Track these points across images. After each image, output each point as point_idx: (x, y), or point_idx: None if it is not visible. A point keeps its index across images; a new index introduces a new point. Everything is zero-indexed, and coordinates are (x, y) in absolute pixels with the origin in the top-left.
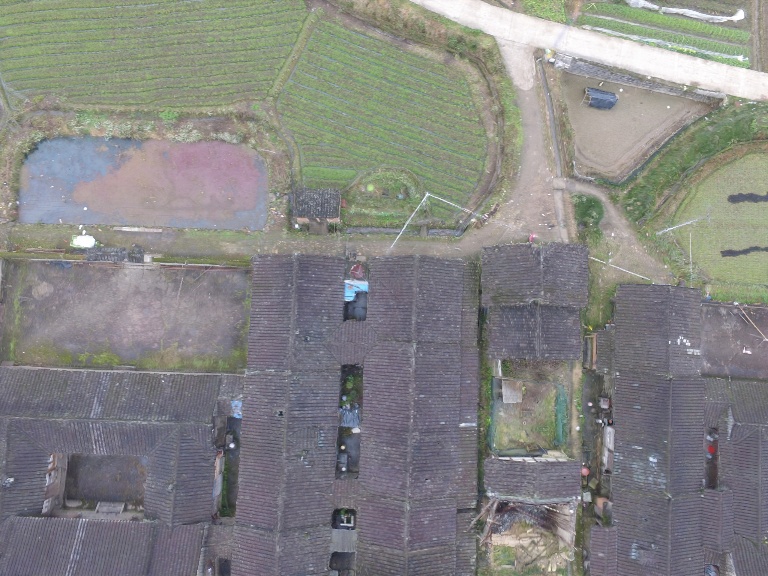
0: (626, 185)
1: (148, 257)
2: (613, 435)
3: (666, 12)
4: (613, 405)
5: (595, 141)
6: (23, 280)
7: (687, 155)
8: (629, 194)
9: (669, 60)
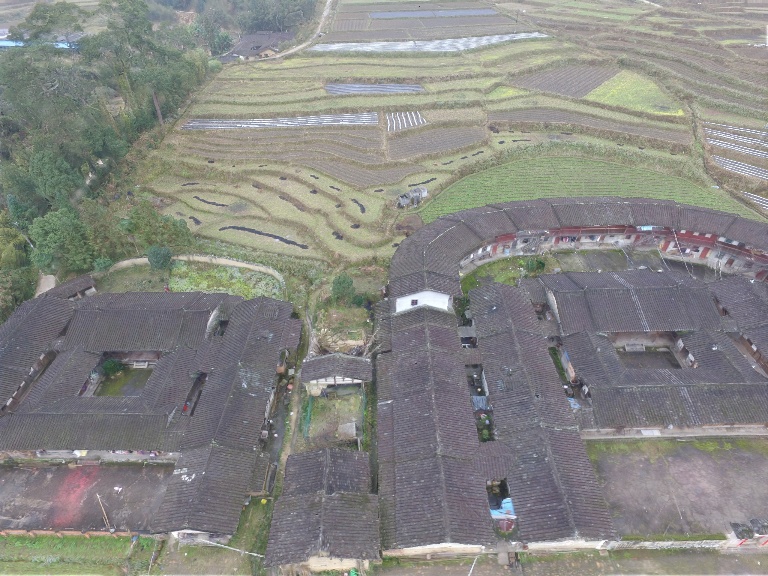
0: None
1: (731, 538)
2: None
3: None
4: None
5: None
6: None
7: None
8: None
9: None
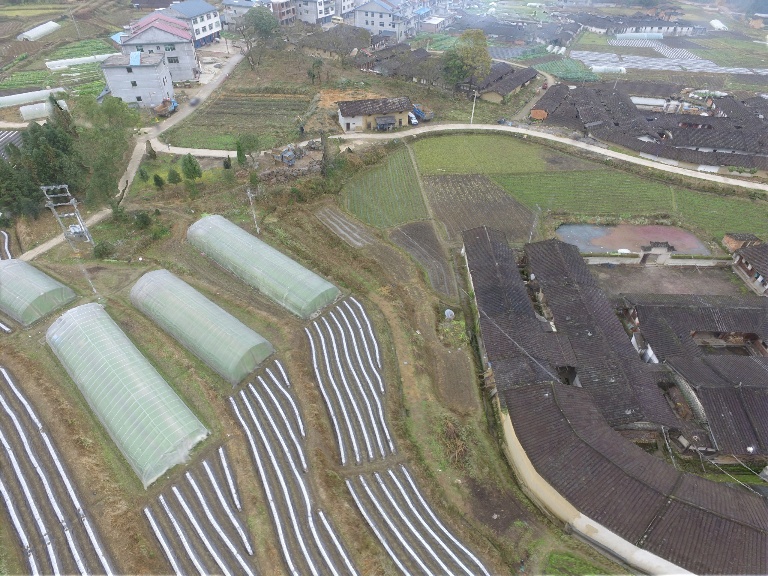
0: None
1: None
2: None
3: None
4: None
5: None
6: None
7: None
8: None
9: None
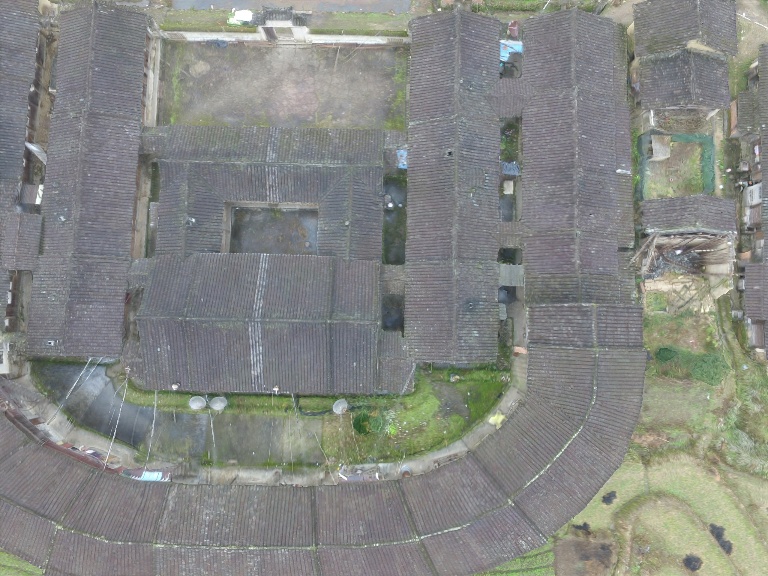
0: None
1: None
2: (757, 189)
3: None
4: (752, 168)
5: None
6: (180, 60)
7: None
8: None
9: None
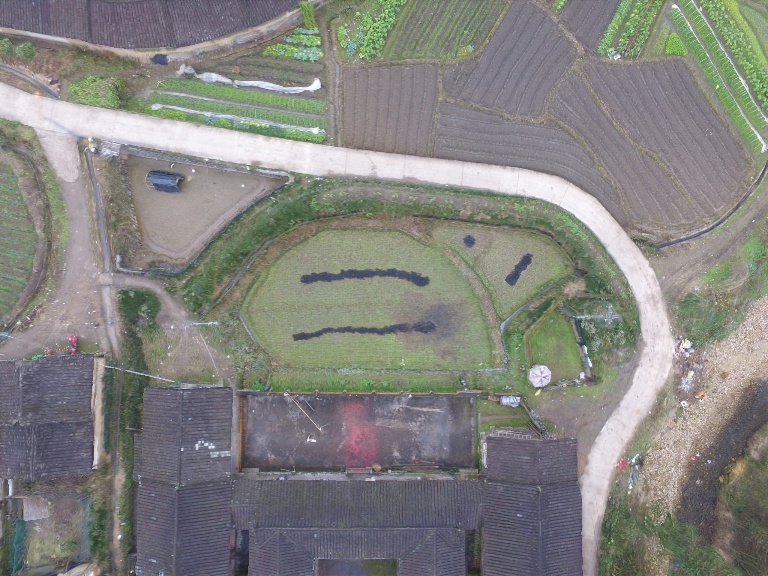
0: (181, 275)
1: None
2: None
3: (241, 85)
4: None
5: (166, 226)
6: None
7: (244, 240)
8: (186, 284)
9: (228, 140)
